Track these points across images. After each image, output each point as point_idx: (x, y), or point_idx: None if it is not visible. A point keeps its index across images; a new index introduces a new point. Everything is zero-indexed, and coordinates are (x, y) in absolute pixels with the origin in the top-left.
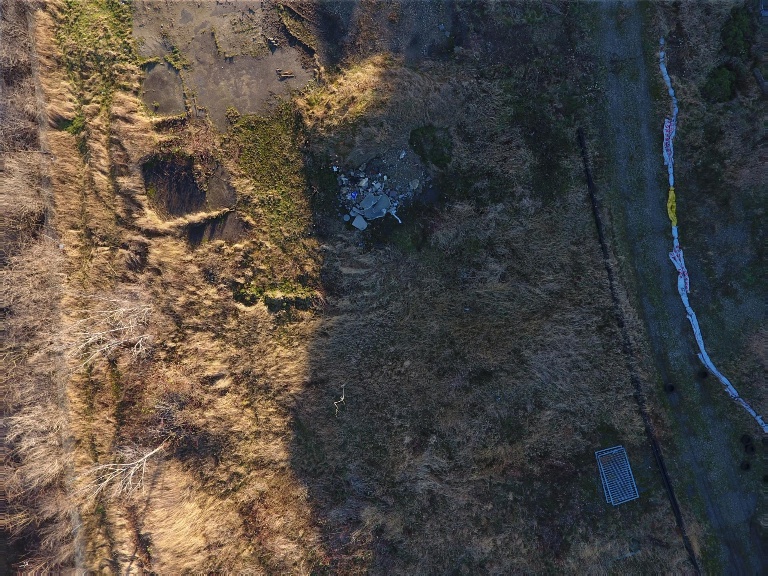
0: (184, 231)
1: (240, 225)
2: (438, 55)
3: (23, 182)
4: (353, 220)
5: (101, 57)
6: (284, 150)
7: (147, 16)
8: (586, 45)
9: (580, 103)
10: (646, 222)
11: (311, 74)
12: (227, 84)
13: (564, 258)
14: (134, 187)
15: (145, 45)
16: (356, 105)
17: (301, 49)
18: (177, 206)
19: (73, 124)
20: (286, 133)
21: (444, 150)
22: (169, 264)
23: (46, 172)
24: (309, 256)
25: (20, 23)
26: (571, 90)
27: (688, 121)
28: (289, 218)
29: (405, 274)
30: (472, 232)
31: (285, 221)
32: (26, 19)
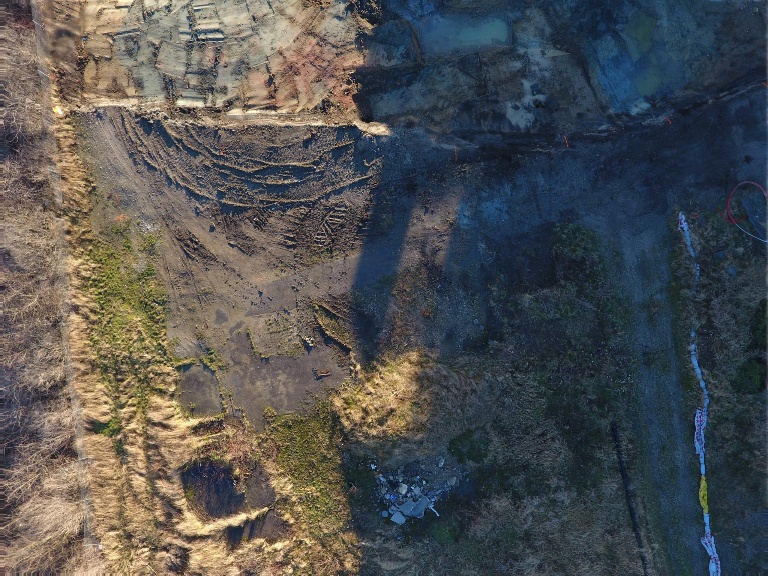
0: (224, 531)
1: (279, 522)
2: (473, 349)
3: (62, 500)
4: (391, 515)
5: (136, 360)
6: (322, 447)
7: (181, 317)
8: (619, 340)
9: (613, 396)
10: (678, 509)
11: (347, 372)
12: (263, 384)
13: (599, 549)
14: (173, 495)
15: (180, 346)
16: (395, 419)
17: (337, 347)
18: (216, 507)
19: (109, 427)
20: (323, 430)
21: (480, 446)
22: (210, 569)
23: (84, 482)
24: (348, 551)
25: (55, 341)
26: (604, 384)
27: (719, 412)
28: (328, 514)
29: (443, 565)
30: (509, 524)
31: (324, 517)
32: (60, 333)
